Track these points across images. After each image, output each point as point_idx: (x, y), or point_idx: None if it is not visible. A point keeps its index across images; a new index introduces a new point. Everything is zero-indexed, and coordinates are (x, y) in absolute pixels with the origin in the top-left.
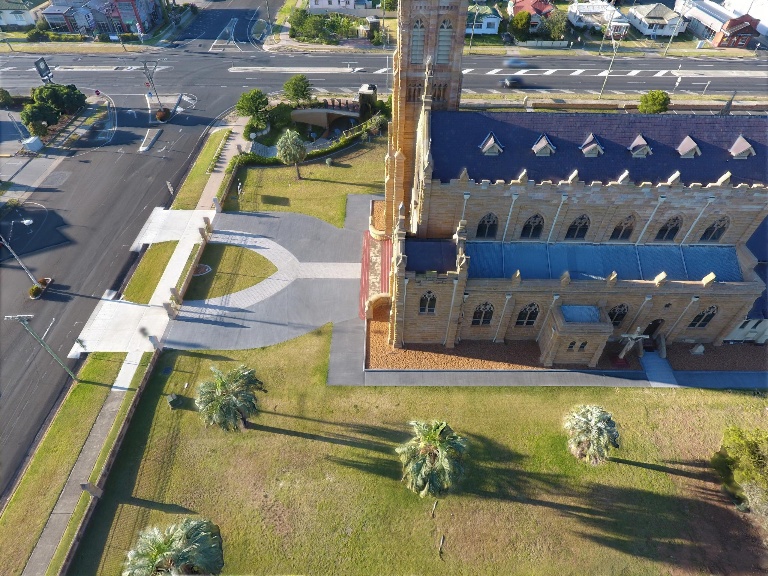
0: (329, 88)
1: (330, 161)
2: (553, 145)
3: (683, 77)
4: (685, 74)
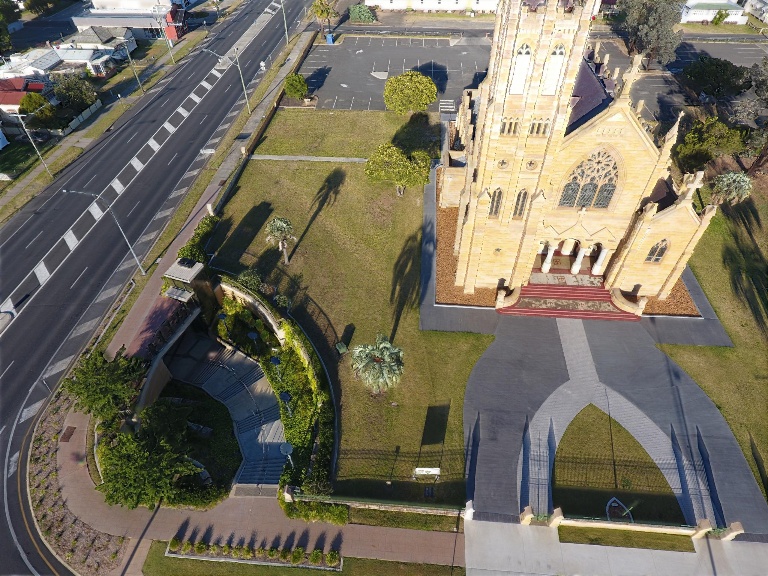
0: (60, 354)
1: (344, 345)
2: None
3: (231, 67)
4: (227, 64)
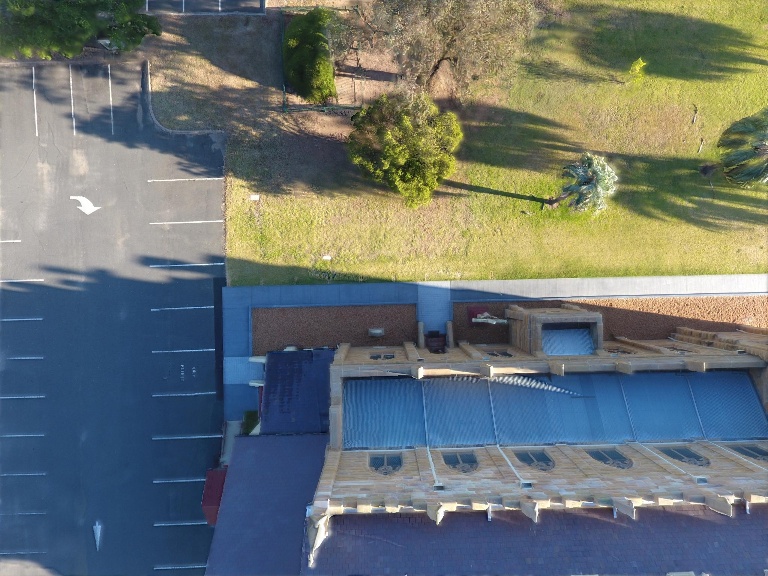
0: None
1: None
2: None
3: None
4: None
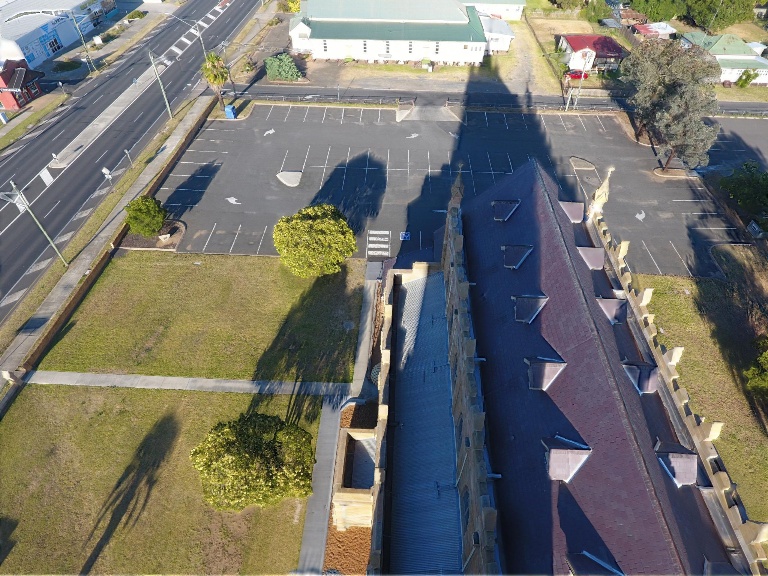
0: None
1: None
2: (657, 441)
3: (74, 163)
4: (69, 159)
